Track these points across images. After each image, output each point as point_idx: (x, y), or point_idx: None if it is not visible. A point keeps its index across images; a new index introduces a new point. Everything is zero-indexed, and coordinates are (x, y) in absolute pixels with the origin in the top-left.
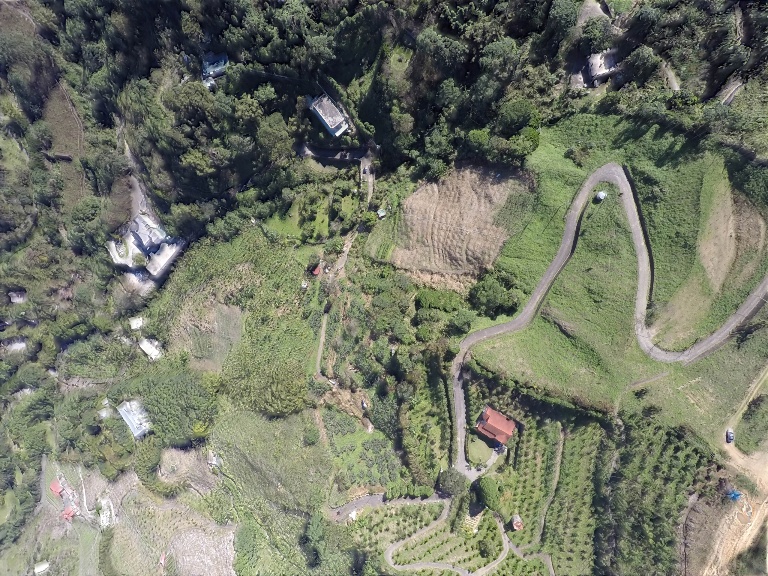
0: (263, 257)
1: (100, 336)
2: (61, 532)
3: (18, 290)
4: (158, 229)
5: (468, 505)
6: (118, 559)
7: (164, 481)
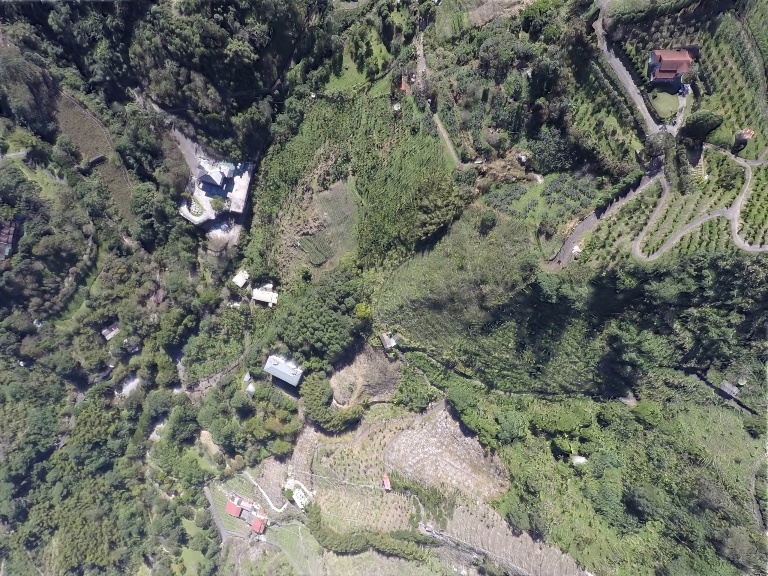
0: (339, 125)
1: (212, 316)
2: (260, 556)
3: (109, 324)
4: (225, 165)
5: (685, 156)
6: (339, 523)
7: (349, 407)
